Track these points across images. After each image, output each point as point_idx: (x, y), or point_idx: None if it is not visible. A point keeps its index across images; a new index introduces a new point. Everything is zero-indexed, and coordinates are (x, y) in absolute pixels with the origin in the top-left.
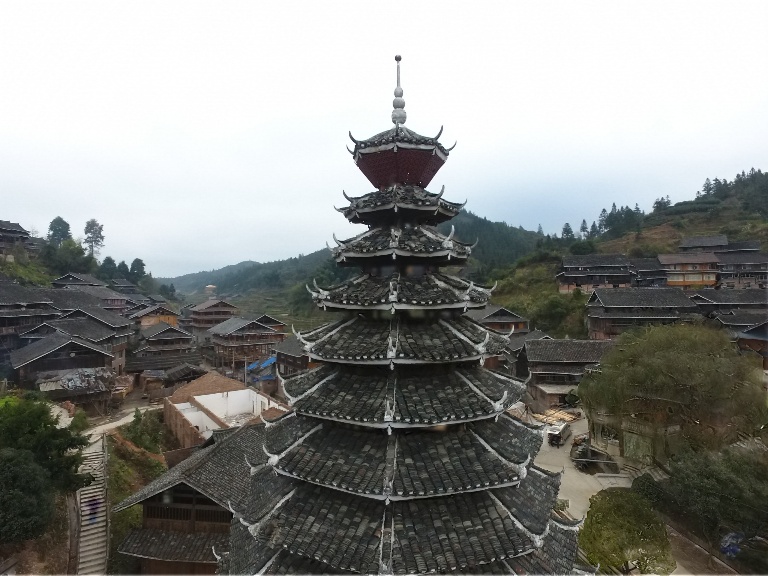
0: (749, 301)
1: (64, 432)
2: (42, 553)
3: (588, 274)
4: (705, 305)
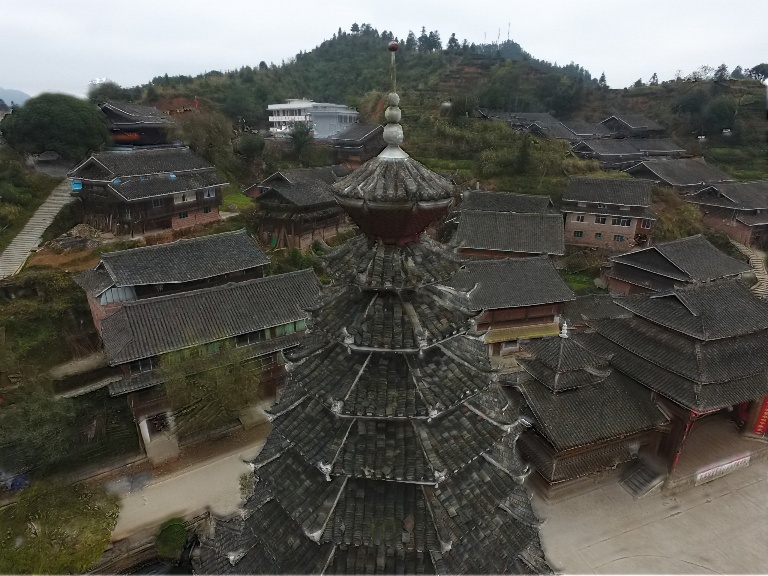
0: None
1: None
2: None
3: None
4: None
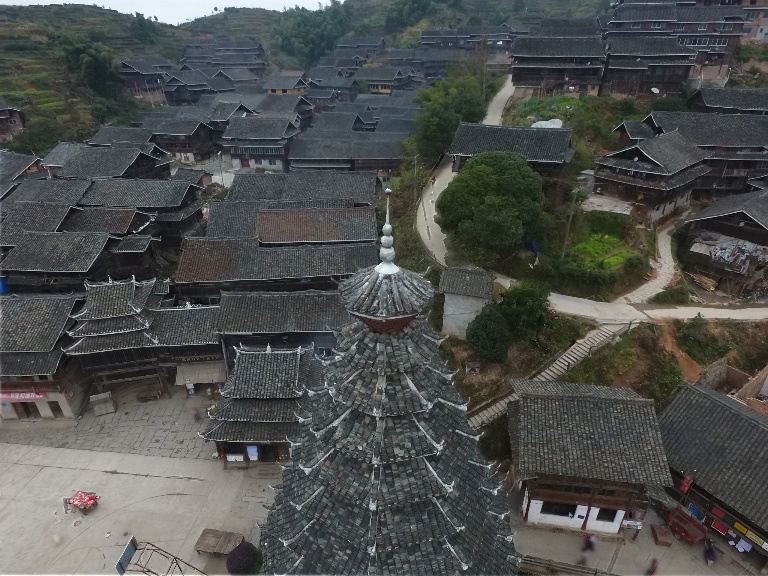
0: None
1: (536, 313)
2: (506, 372)
3: None
4: None
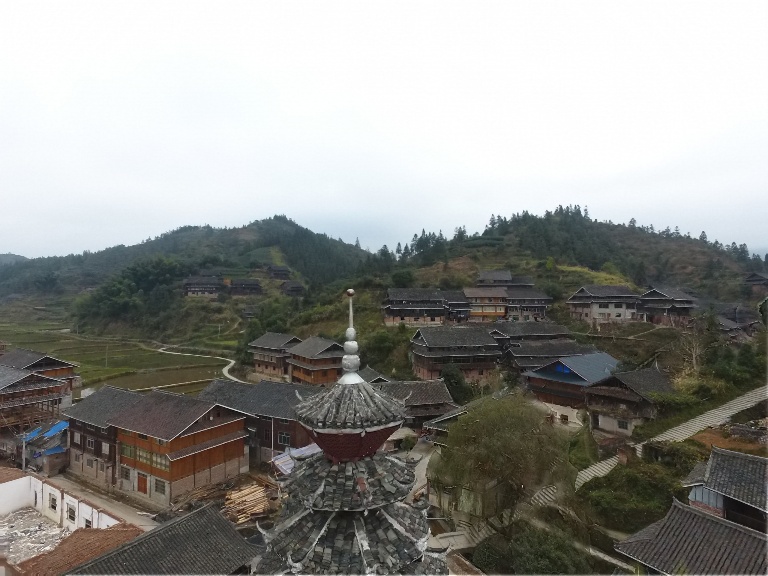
0: (529, 333)
1: None
2: None
3: (410, 308)
4: (501, 339)
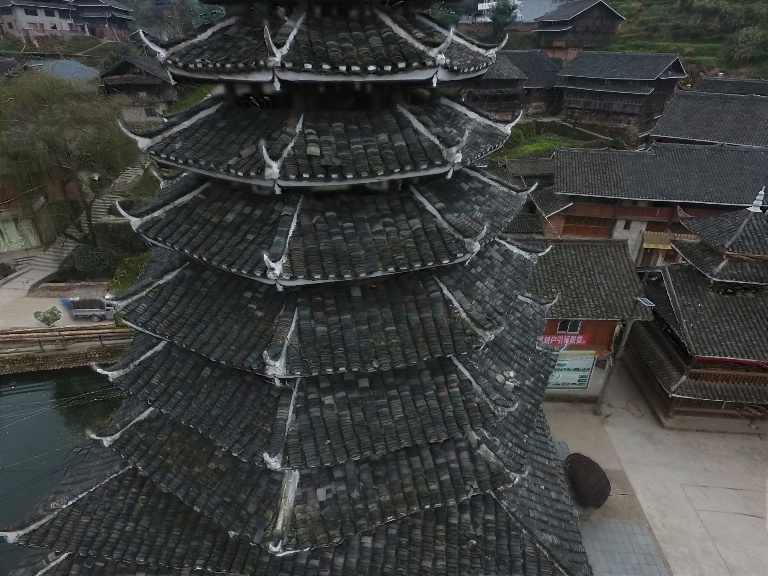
0: None
1: None
2: None
3: None
4: None
